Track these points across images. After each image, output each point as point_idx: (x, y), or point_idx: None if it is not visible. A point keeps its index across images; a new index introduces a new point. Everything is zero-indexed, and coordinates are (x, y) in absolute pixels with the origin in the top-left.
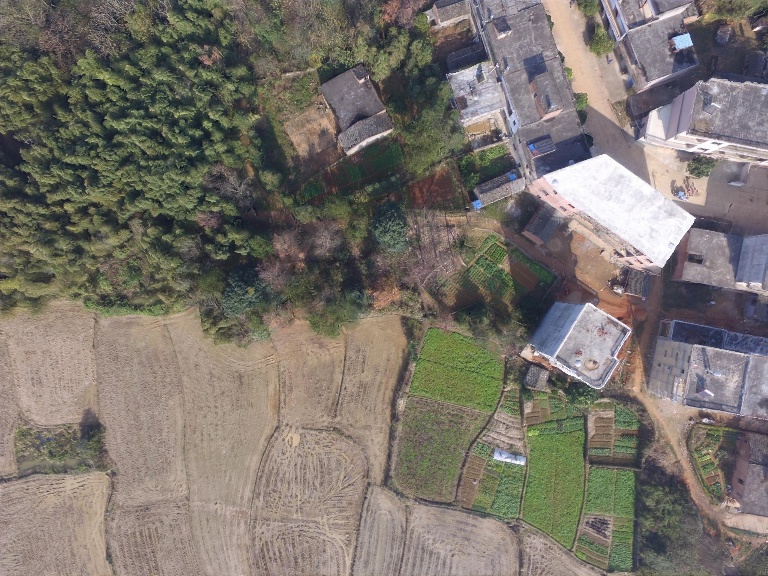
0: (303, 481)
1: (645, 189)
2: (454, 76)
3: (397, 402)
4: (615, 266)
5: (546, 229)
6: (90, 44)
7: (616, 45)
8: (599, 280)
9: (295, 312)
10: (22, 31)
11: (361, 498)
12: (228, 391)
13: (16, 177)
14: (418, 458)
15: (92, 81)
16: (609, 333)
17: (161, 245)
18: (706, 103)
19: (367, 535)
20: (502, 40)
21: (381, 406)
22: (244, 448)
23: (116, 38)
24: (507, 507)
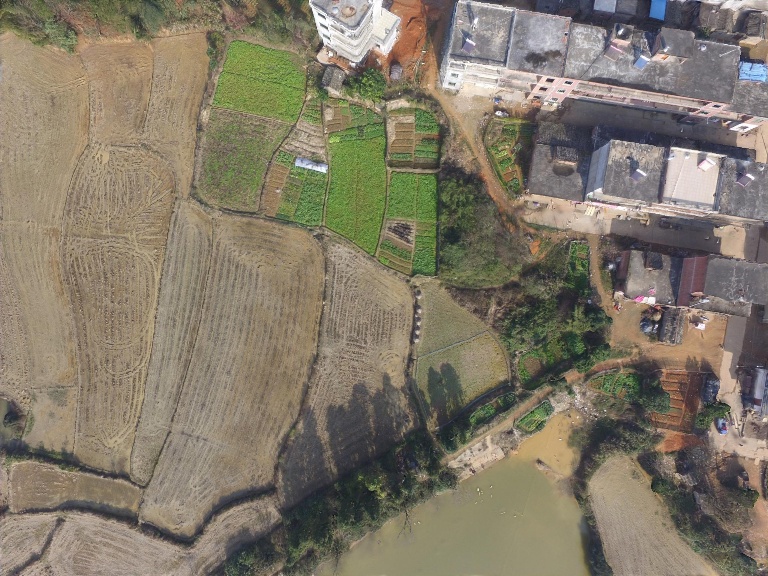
0: (112, 197)
1: None
2: None
3: (201, 114)
4: None
5: None
6: None
7: None
8: None
9: (102, 30)
10: None
11: (169, 213)
12: (40, 112)
13: None
14: (222, 169)
15: None
16: None
17: None
18: None
19: (174, 249)
20: None
21: (188, 122)
22: (56, 167)
23: None
24: (310, 214)
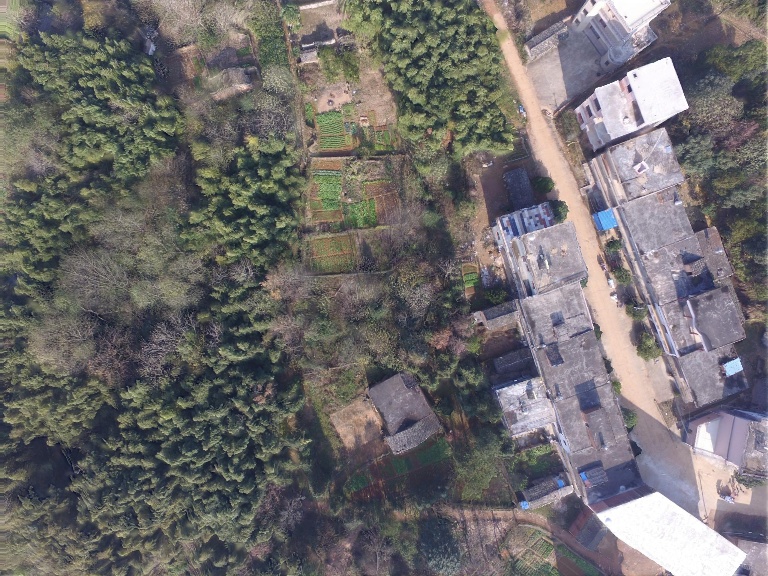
0: None
1: (697, 526)
2: (504, 391)
3: None
4: None
5: (595, 540)
6: (142, 379)
7: (664, 354)
8: None
9: None
10: (71, 352)
11: None
12: None
13: (66, 498)
14: None
15: (144, 412)
16: None
17: (213, 569)
18: (758, 441)
19: None
20: None
21: None
22: None
23: (167, 365)
24: None
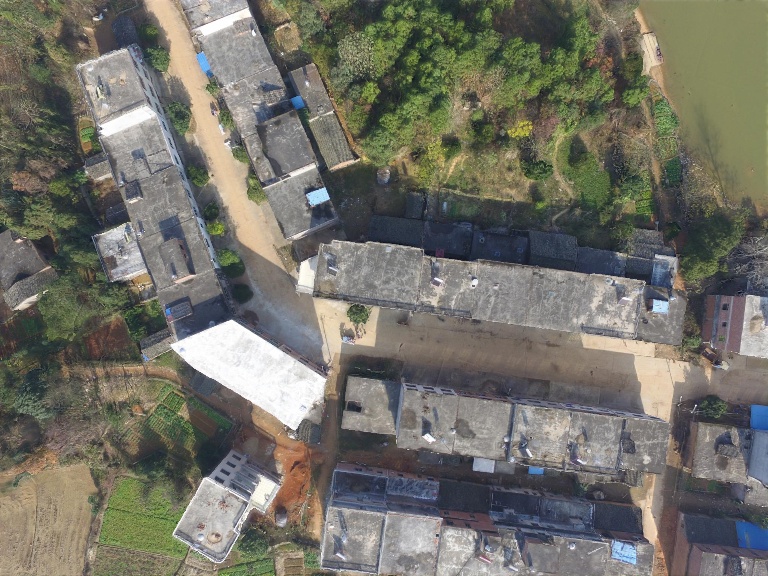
0: None
1: (274, 353)
2: (102, 236)
3: (87, 552)
4: None
5: (205, 384)
6: None
7: None
8: (276, 425)
9: None
10: None
11: None
12: None
13: None
14: None
15: None
16: (230, 505)
17: None
18: (330, 264)
19: None
20: (136, 204)
21: (75, 555)
22: None
23: None
24: None
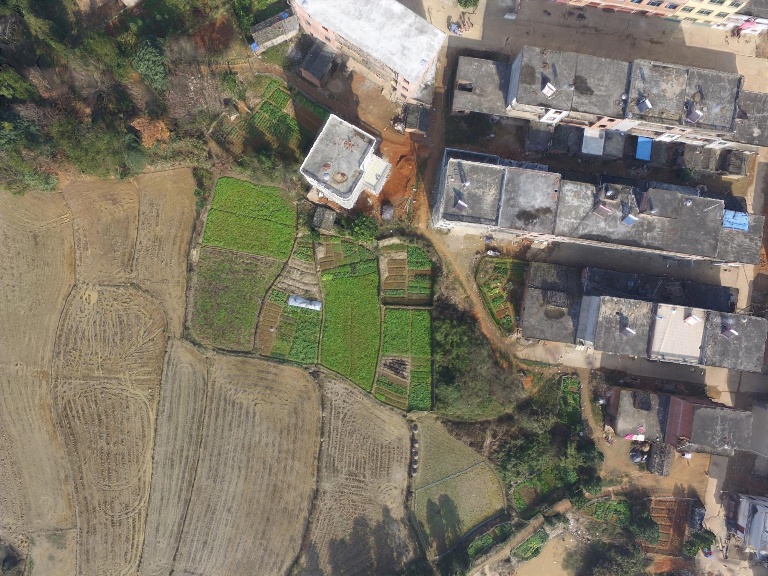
0: (102, 338)
1: (395, 7)
2: None
3: (190, 253)
4: (397, 105)
5: (317, 64)
6: None
7: None
8: (382, 120)
9: None
10: None
11: (162, 353)
12: (23, 252)
13: None
14: (214, 308)
15: None
16: (356, 145)
17: None
18: None
19: (169, 389)
20: None
21: (177, 260)
22: (42, 308)
23: None
24: (305, 353)
